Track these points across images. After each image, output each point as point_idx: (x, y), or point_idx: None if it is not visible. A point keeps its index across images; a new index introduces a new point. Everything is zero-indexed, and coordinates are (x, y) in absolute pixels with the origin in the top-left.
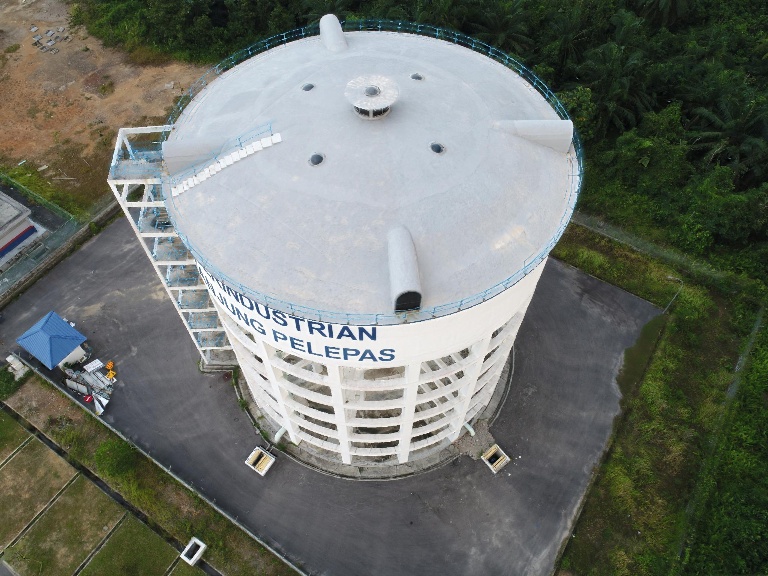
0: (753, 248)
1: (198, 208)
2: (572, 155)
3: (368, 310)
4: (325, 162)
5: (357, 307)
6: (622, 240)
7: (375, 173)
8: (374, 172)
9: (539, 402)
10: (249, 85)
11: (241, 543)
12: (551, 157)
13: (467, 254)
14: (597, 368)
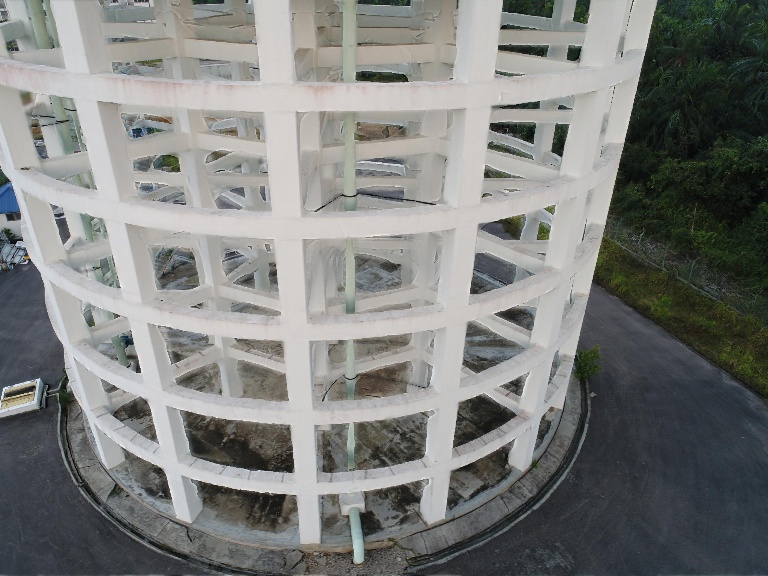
0: None
1: None
2: None
3: None
4: None
5: None
6: None
7: None
8: None
9: None
10: None
11: None
12: None
13: None
14: None
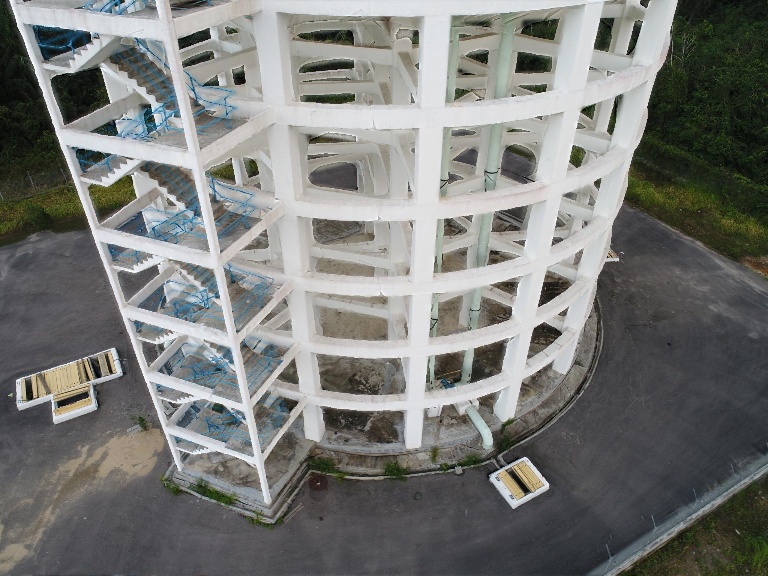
0: None
1: None
2: None
3: None
4: None
5: None
6: None
7: None
8: None
9: None
10: None
11: (668, 572)
12: None
13: None
14: (521, 169)
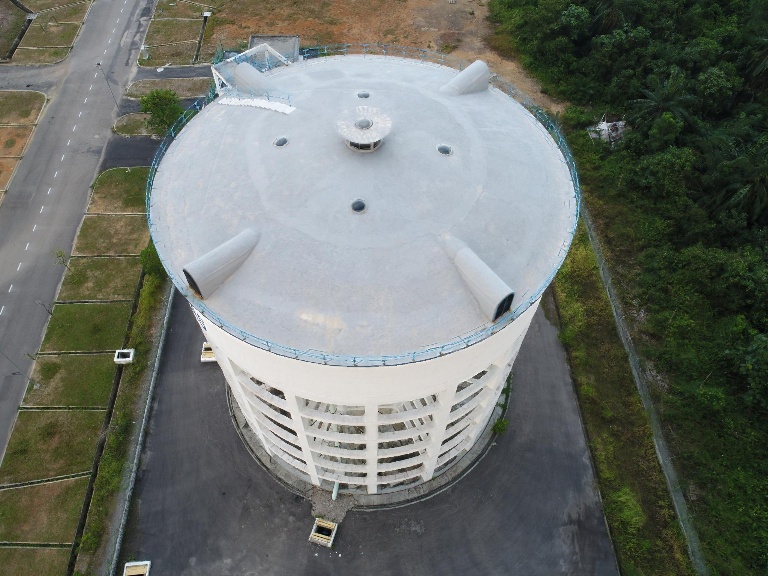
0: None
1: (211, 119)
2: (494, 327)
3: (180, 266)
4: (282, 148)
5: (179, 257)
6: (687, 531)
7: (293, 182)
8: (294, 181)
9: (410, 543)
10: (352, 69)
11: (146, 382)
12: (464, 307)
13: (275, 297)
14: None
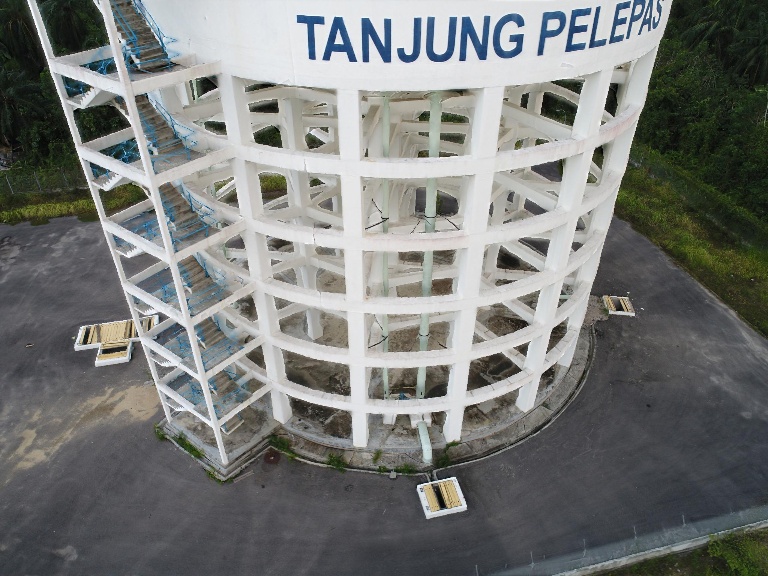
0: (547, 110)
1: None
2: None
3: None
4: None
5: None
6: None
7: None
8: None
9: None
10: None
11: None
12: None
13: None
14: None
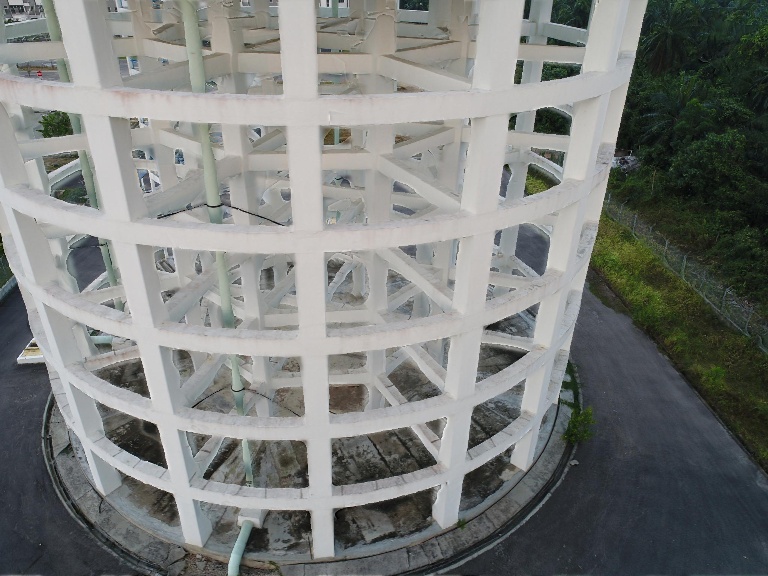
0: None
1: None
2: None
3: None
4: None
5: None
6: None
7: None
8: None
9: None
10: None
11: None
12: None
13: None
14: None
